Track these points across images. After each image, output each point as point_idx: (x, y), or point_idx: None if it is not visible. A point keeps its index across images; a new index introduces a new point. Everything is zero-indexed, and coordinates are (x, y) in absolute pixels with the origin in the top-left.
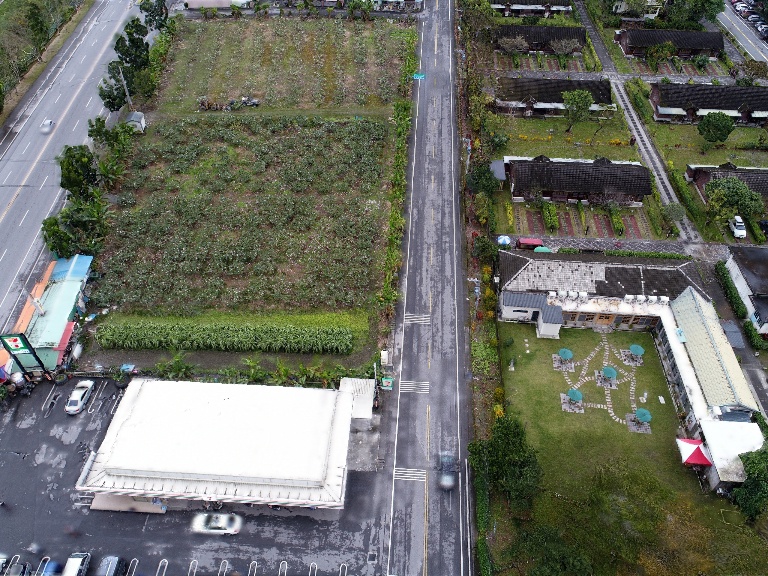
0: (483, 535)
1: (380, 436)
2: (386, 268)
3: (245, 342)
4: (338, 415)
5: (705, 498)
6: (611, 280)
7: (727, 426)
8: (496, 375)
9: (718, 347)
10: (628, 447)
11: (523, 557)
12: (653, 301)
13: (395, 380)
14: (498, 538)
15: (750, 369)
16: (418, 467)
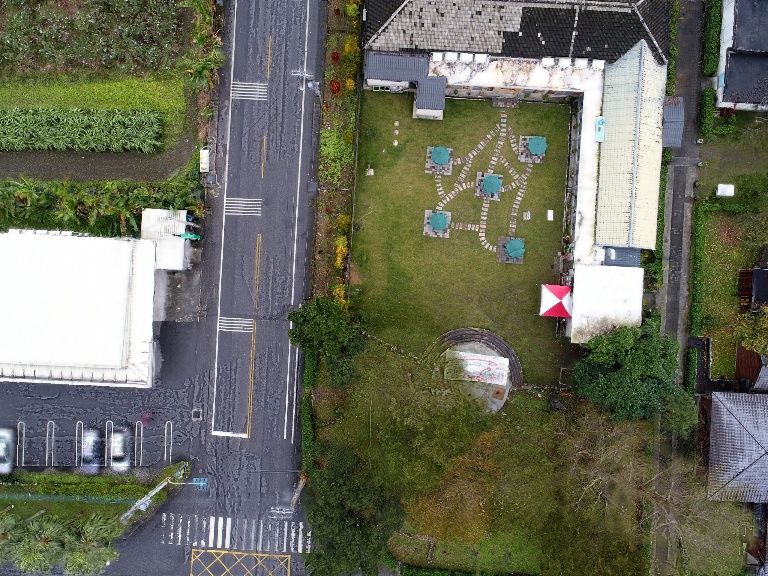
0: (308, 394)
1: (202, 277)
2: (196, 3)
3: (16, 144)
4: (137, 275)
5: (555, 344)
6: (528, 31)
7: (605, 273)
8: (348, 184)
9: (640, 156)
10: (489, 283)
11: (346, 414)
12: (581, 67)
13: (219, 197)
14: (324, 394)
15: (681, 165)
16: (245, 316)
